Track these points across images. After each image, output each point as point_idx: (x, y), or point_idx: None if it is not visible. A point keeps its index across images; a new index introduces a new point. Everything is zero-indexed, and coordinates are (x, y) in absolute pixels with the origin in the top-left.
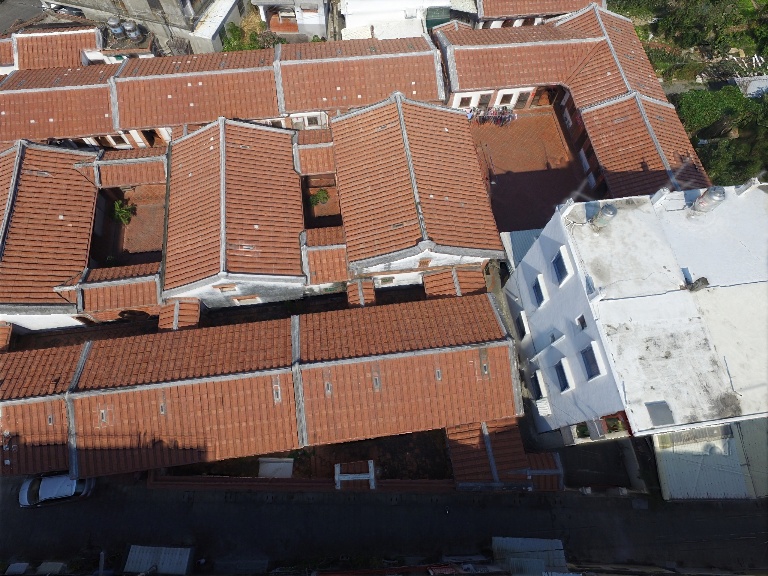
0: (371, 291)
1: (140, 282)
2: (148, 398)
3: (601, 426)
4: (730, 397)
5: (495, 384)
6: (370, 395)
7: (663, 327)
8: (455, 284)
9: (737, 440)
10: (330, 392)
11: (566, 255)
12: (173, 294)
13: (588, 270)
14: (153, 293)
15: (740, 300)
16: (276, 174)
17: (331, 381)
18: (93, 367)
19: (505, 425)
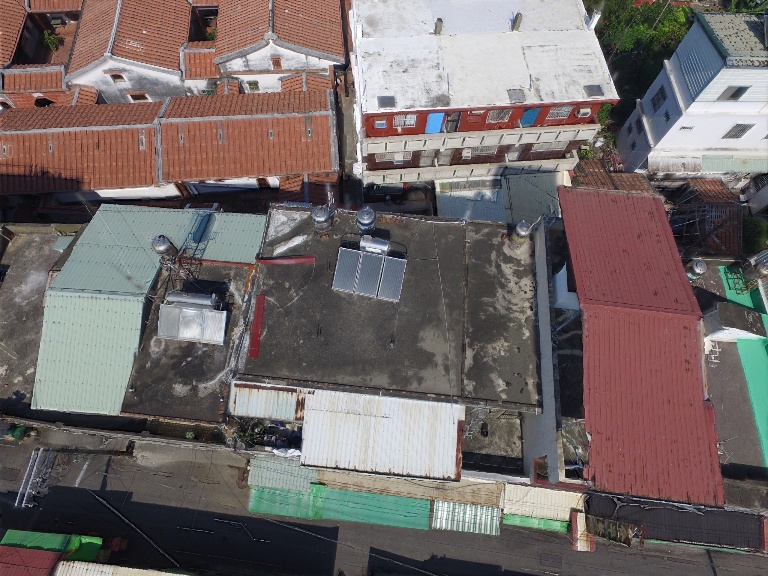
0: (236, 88)
1: (49, 71)
2: (40, 139)
3: (362, 134)
4: (444, 96)
5: (317, 145)
6: (215, 146)
7: (407, 55)
8: (303, 83)
9: (504, 190)
10: (183, 142)
11: (351, 15)
12: (73, 77)
13: (362, 21)
14: (59, 80)
15: (473, 42)
16: (170, 1)
17: (184, 133)
18: (2, 121)
19: (326, 181)
